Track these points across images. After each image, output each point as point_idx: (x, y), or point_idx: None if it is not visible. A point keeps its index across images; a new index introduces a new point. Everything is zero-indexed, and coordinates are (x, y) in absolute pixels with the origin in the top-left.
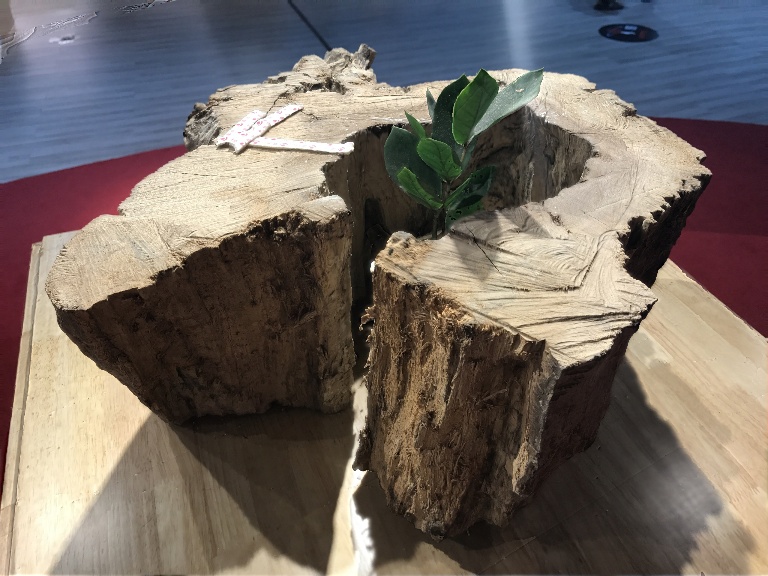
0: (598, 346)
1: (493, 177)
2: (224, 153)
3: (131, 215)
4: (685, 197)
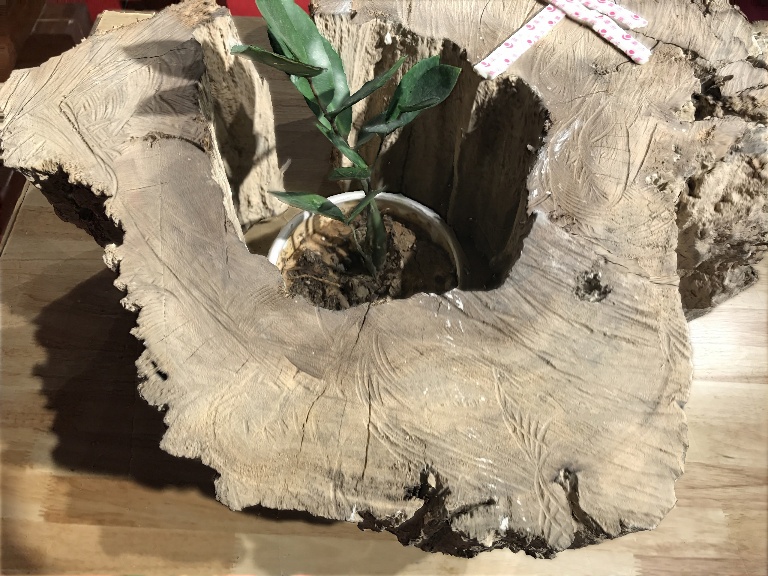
0: (5, 96)
1: None
2: None
3: None
4: None
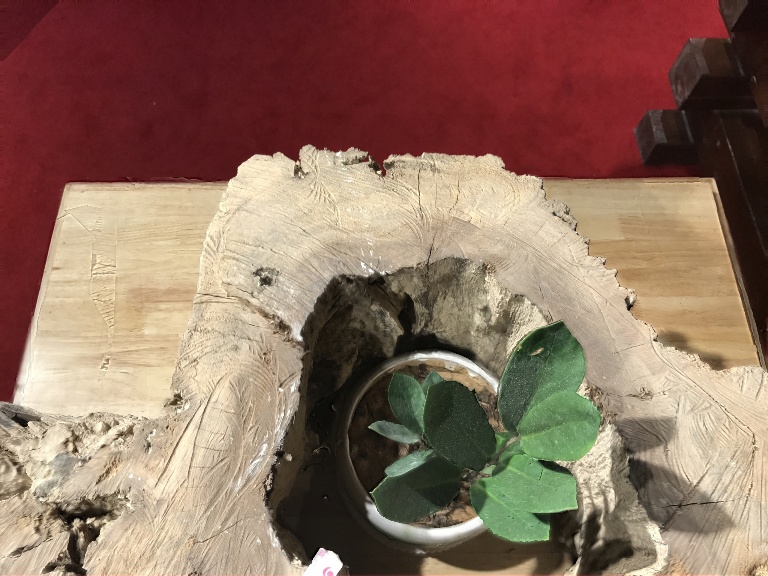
0: None
1: (336, 347)
2: None
3: None
4: None
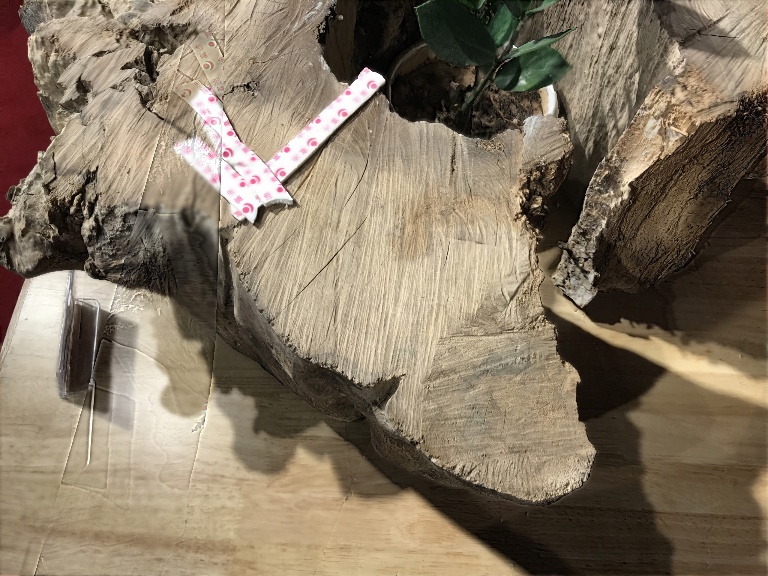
0: None
1: None
2: (278, 220)
3: (410, 367)
4: None
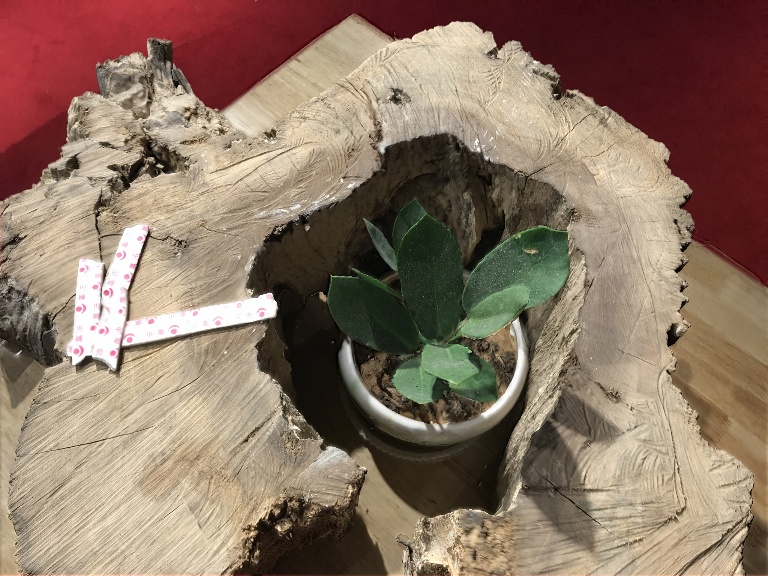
0: None
1: None
2: (94, 376)
3: None
4: (685, 248)
